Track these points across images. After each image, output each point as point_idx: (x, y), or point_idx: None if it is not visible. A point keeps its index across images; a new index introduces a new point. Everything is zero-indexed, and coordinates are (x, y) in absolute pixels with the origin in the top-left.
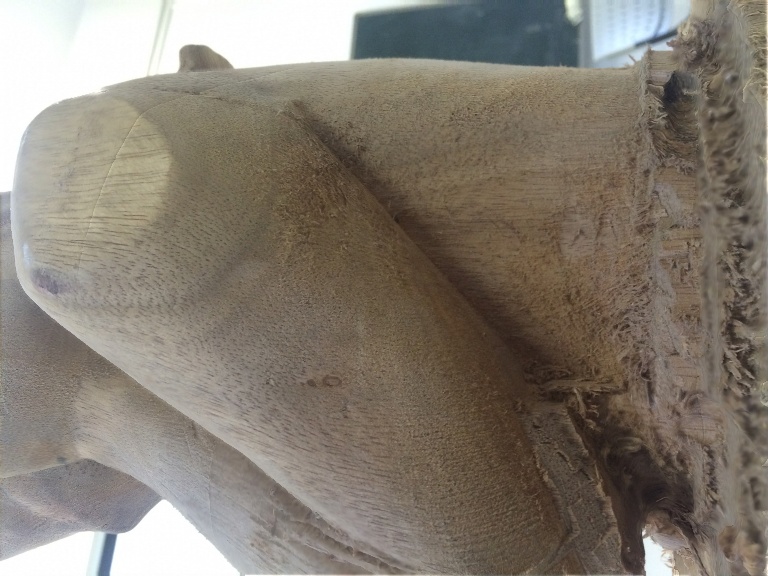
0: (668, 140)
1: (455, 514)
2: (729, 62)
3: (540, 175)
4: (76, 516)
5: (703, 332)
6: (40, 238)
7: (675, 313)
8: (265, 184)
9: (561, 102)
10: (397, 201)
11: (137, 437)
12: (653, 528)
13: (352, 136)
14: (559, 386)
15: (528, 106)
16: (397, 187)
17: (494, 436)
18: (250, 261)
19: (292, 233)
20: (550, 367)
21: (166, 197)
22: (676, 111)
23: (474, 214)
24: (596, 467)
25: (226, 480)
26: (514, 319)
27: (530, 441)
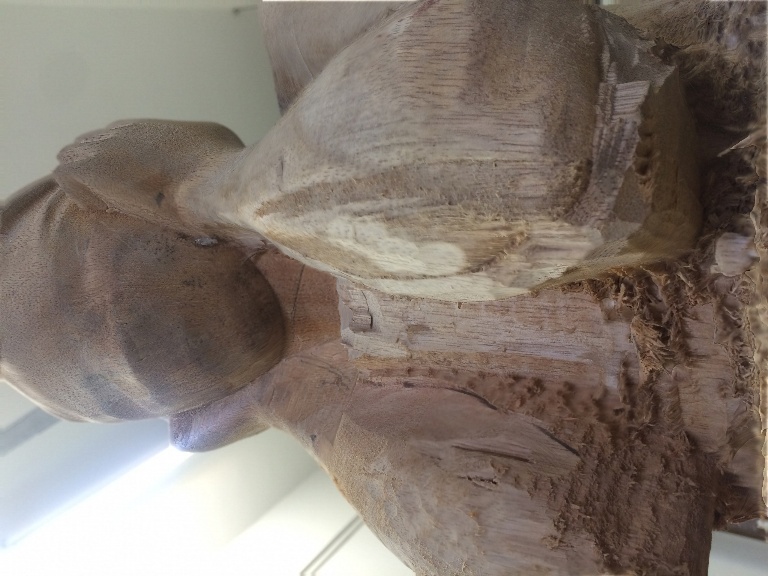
0: None
1: None
2: None
3: None
4: (115, 295)
5: None
6: None
7: None
8: None
9: None
10: None
11: None
12: (715, 234)
13: None
14: None
15: None
16: None
17: None
18: None
19: None
20: None
21: None
22: None
23: None
24: None
25: None
26: None
27: None
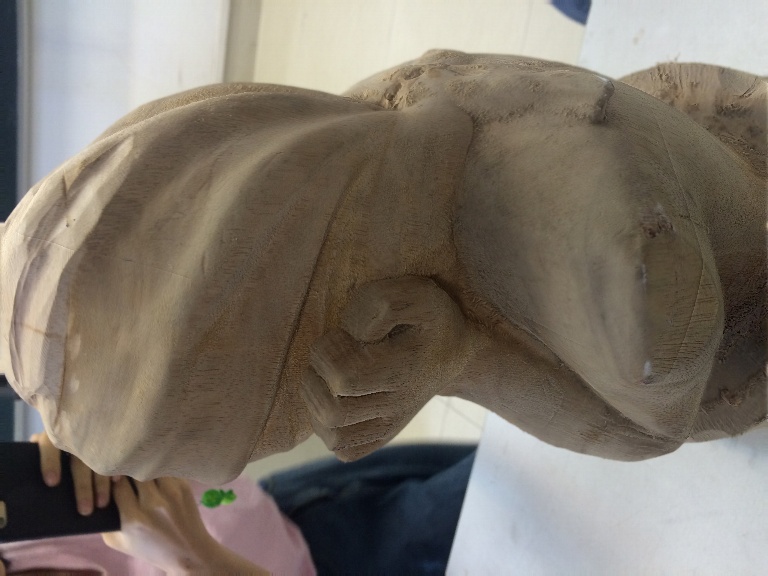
0: None
1: None
2: None
3: None
4: None
5: (761, 334)
6: (657, 358)
7: (755, 324)
8: None
9: (763, 216)
10: None
11: (501, 386)
12: None
13: None
14: None
15: None
16: None
17: None
18: None
19: None
20: None
21: None
22: None
23: None
24: None
25: (573, 408)
26: None
27: None
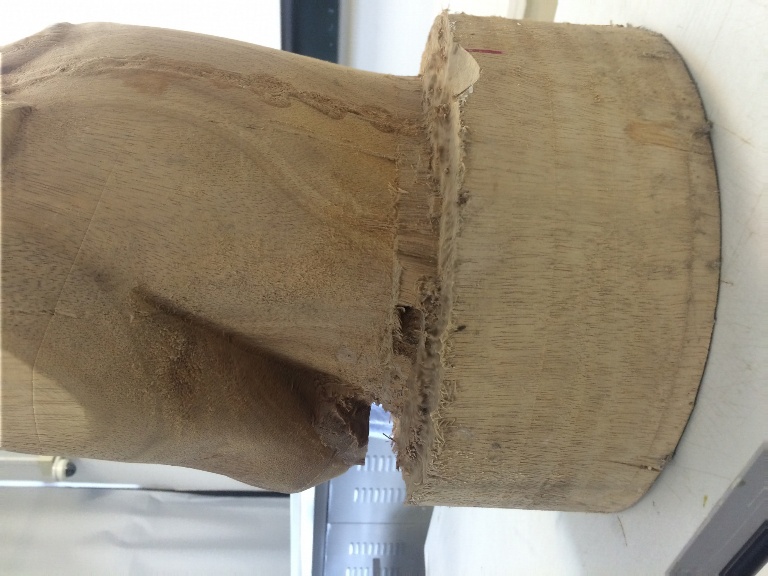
0: (402, 341)
1: (285, 478)
2: (440, 334)
3: (325, 330)
4: None
5: None
6: None
7: (392, 404)
8: (151, 400)
9: (340, 293)
10: (229, 330)
11: None
12: None
13: (188, 306)
14: (333, 394)
15: (318, 295)
16: (228, 325)
17: (301, 447)
18: (159, 441)
19: (179, 422)
20: (328, 377)
21: (91, 429)
22: (410, 320)
23: (283, 337)
24: (349, 427)
25: None
26: (308, 366)
27: (318, 435)
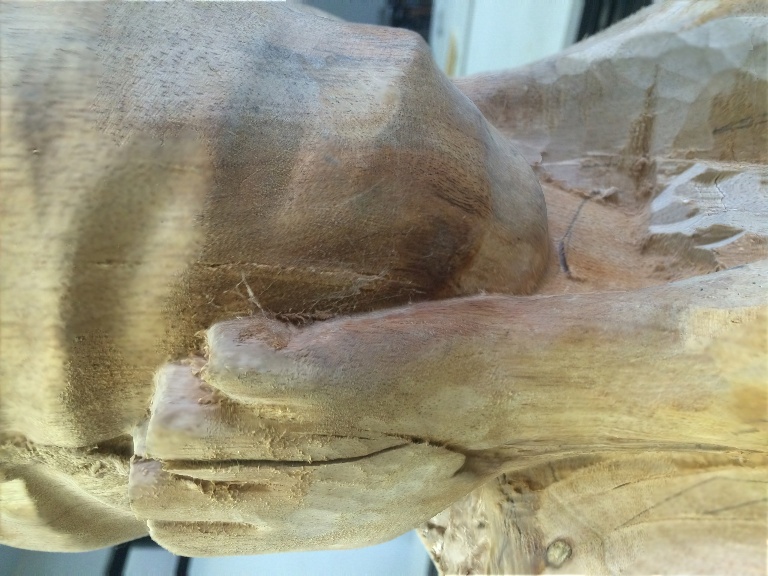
0: None
1: None
2: None
3: None
4: None
5: None
6: None
7: None
8: None
9: None
10: None
11: None
12: None
13: None
14: None
15: None
16: None
17: None
18: None
19: None
20: None
21: None
22: None
23: None
24: None
25: None
26: None
27: None
